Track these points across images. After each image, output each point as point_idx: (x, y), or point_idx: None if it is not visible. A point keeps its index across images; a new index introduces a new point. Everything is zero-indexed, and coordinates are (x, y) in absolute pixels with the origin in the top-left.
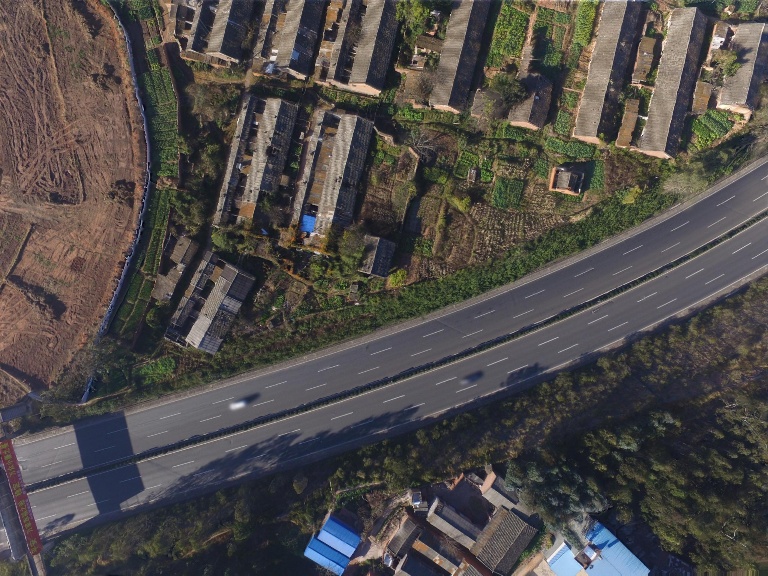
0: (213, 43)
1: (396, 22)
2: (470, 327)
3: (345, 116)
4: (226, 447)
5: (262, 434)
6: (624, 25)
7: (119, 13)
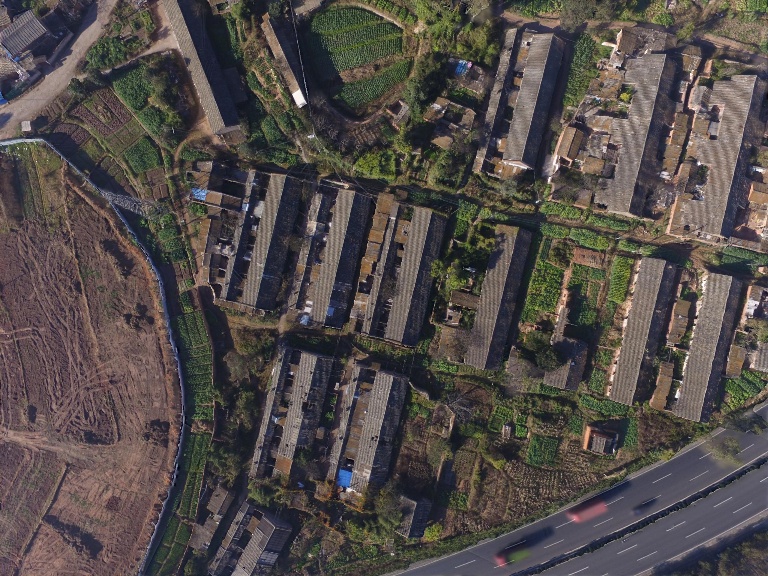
0: (248, 295)
1: (431, 277)
2: (501, 558)
3: (381, 373)
4: None
5: None
6: (660, 293)
7: (151, 255)
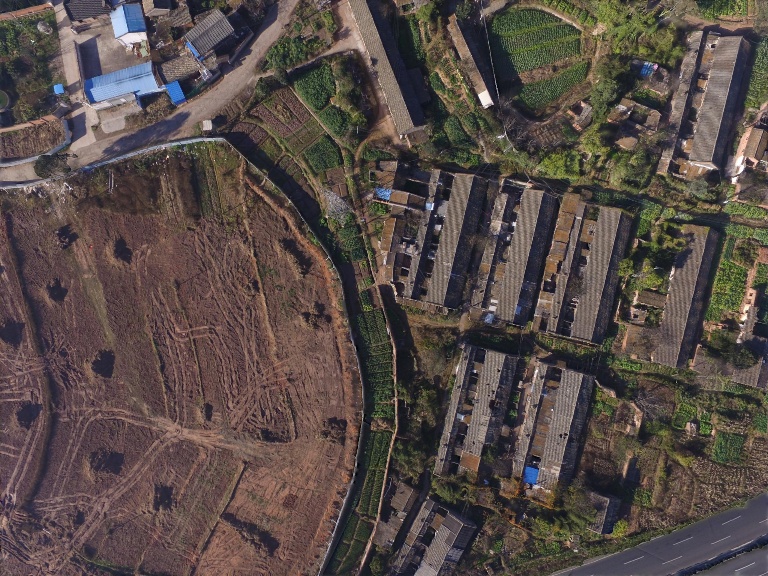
0: (433, 294)
1: (617, 276)
2: (669, 554)
3: (568, 371)
4: None
5: None
6: None
7: (331, 254)
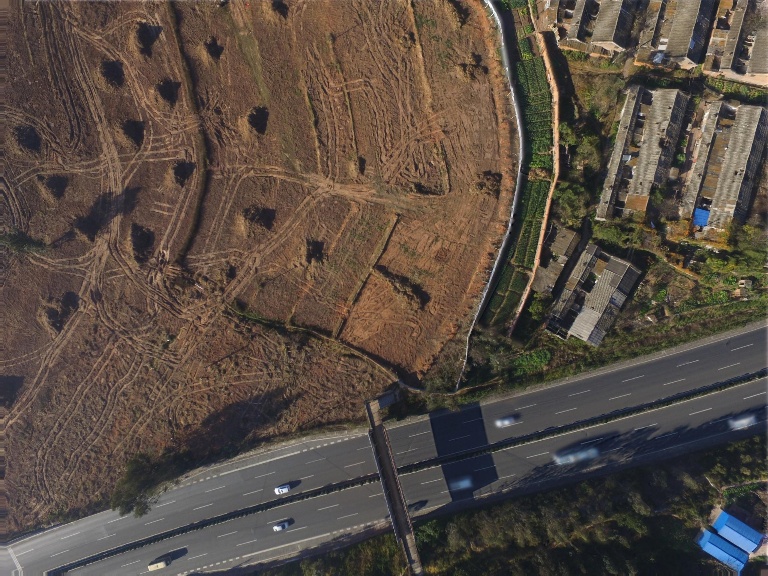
0: (601, 32)
1: None
2: None
3: (744, 107)
4: (582, 439)
5: (619, 427)
6: None
7: (491, 1)
